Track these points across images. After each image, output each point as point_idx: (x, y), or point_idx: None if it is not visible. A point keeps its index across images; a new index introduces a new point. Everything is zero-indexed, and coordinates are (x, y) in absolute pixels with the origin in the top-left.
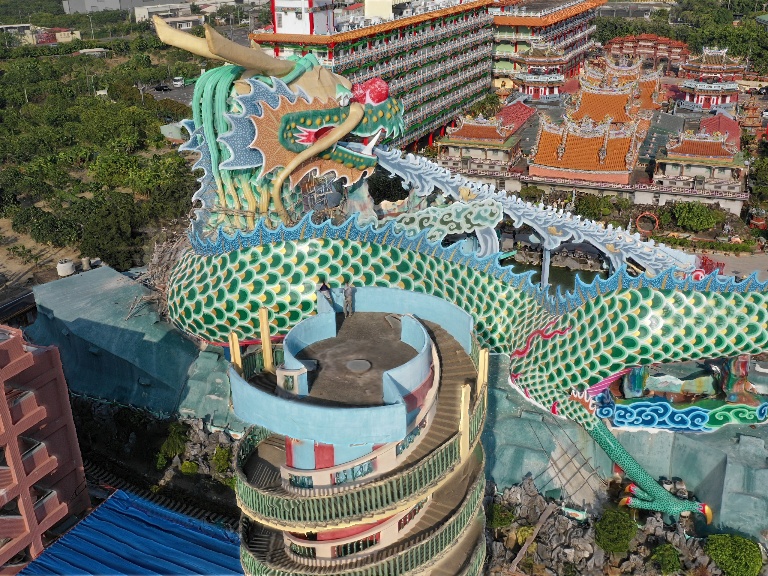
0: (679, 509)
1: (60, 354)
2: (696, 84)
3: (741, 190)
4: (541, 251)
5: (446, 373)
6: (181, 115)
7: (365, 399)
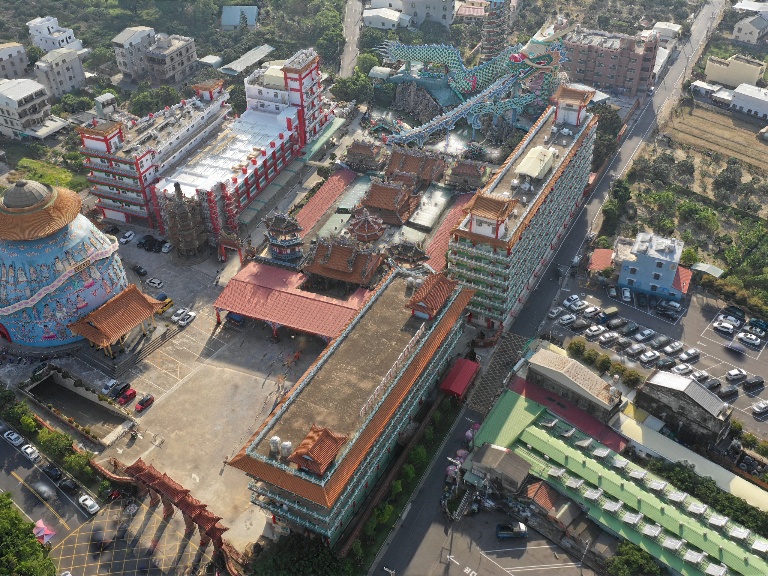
0: None
1: None
2: None
3: None
4: (446, 153)
5: None
6: None
7: None
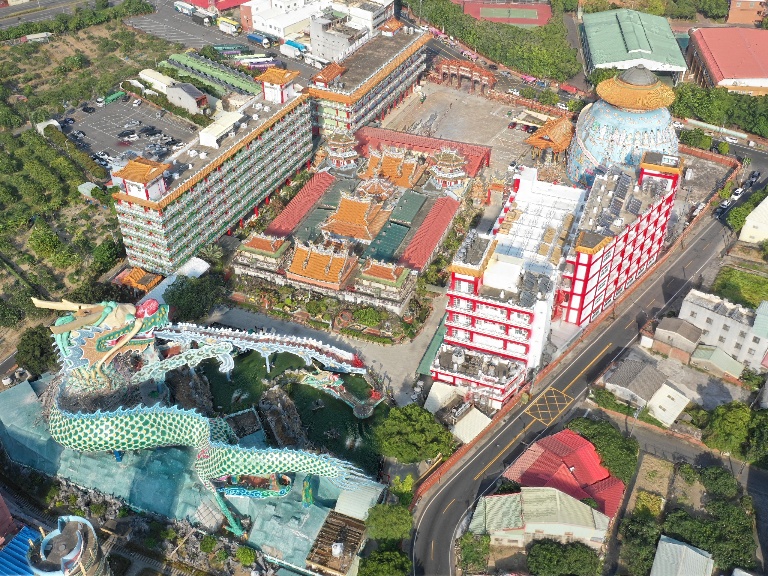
0: (238, 533)
1: (6, 436)
2: (437, 172)
3: (402, 297)
4: None
5: (88, 546)
6: (93, 173)
7: (60, 562)
